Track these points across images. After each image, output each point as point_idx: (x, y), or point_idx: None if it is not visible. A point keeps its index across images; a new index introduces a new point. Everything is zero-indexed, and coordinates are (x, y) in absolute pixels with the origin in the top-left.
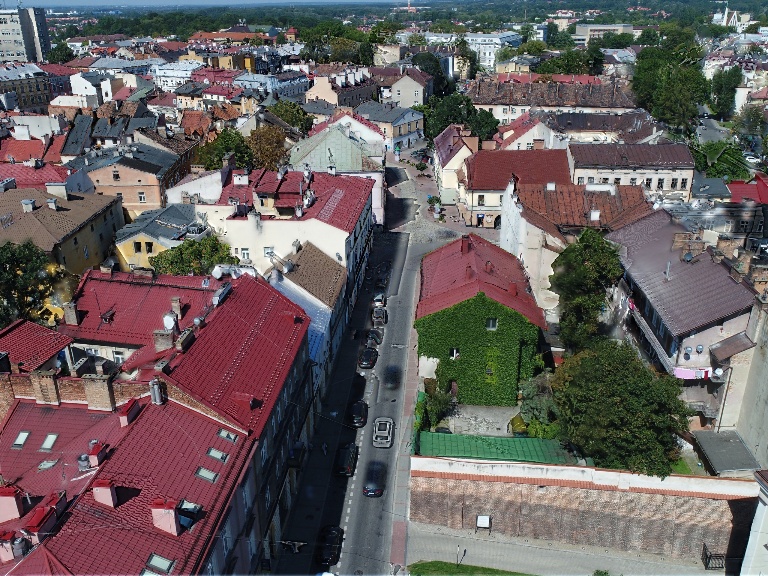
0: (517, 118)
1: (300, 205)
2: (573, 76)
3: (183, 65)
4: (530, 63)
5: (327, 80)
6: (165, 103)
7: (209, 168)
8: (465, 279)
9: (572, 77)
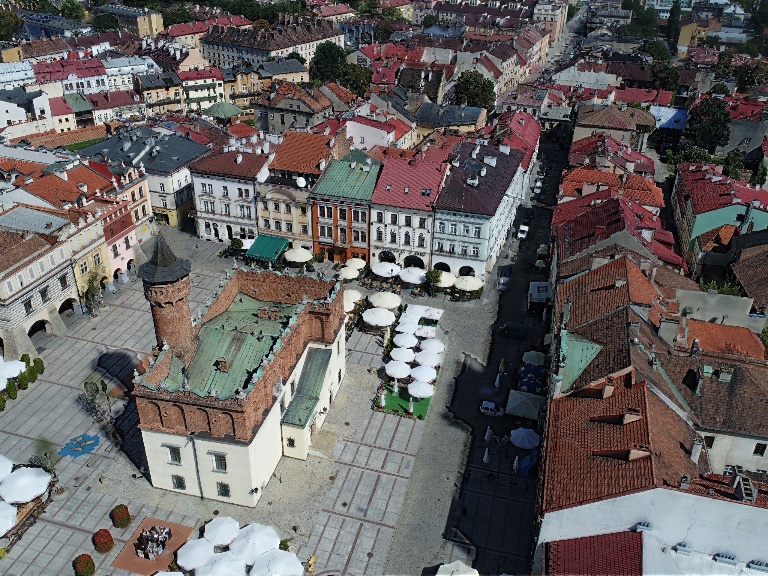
0: (385, 49)
1: (596, 89)
2: (231, 19)
3: (1, 66)
4: (160, 12)
5: (198, 51)
6: (124, 103)
7: None
8: (650, 93)
9: (230, 19)
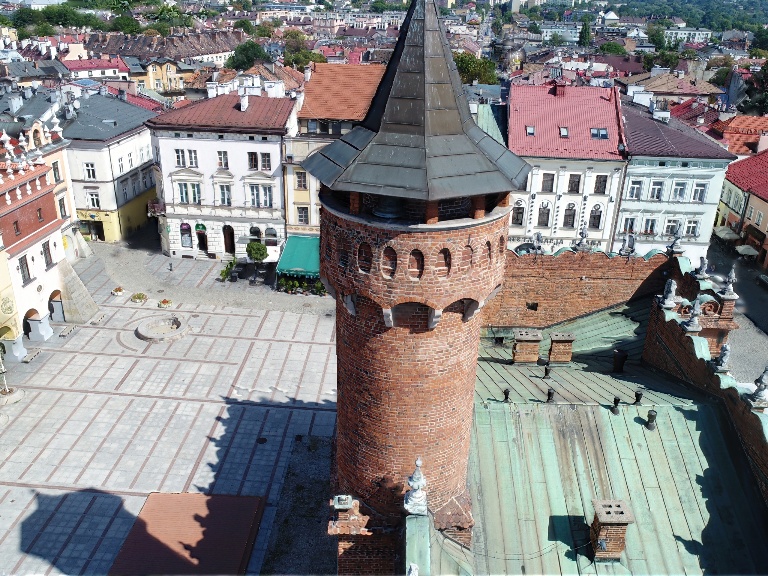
0: None
1: None
2: None
3: None
4: None
5: (82, 47)
6: None
7: (493, 82)
8: None
9: None
